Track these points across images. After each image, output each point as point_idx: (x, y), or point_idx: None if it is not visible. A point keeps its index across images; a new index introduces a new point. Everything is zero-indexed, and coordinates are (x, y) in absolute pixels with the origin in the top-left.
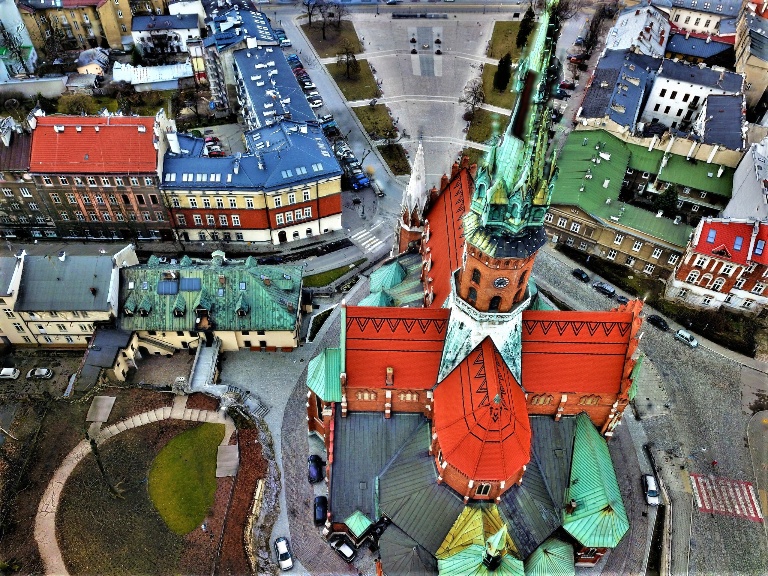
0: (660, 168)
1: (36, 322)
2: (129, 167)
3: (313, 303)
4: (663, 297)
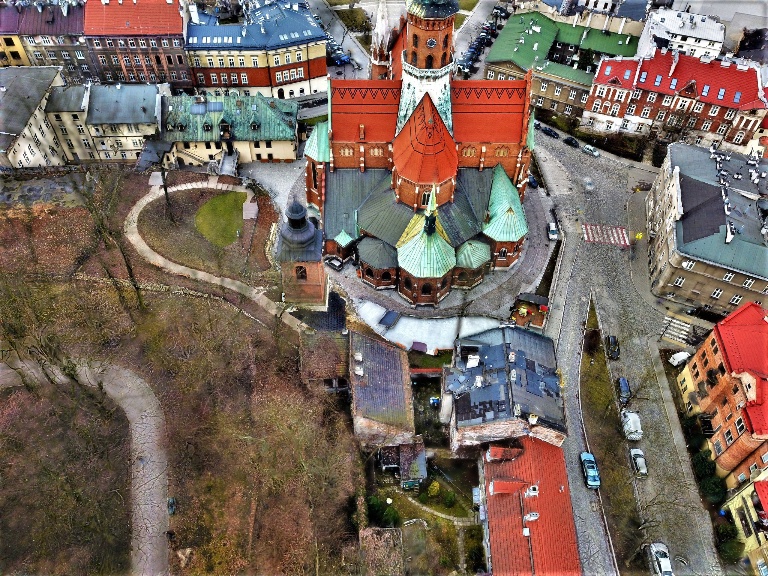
0: (581, 39)
1: (100, 138)
2: (161, 30)
3: (307, 135)
4: (577, 128)
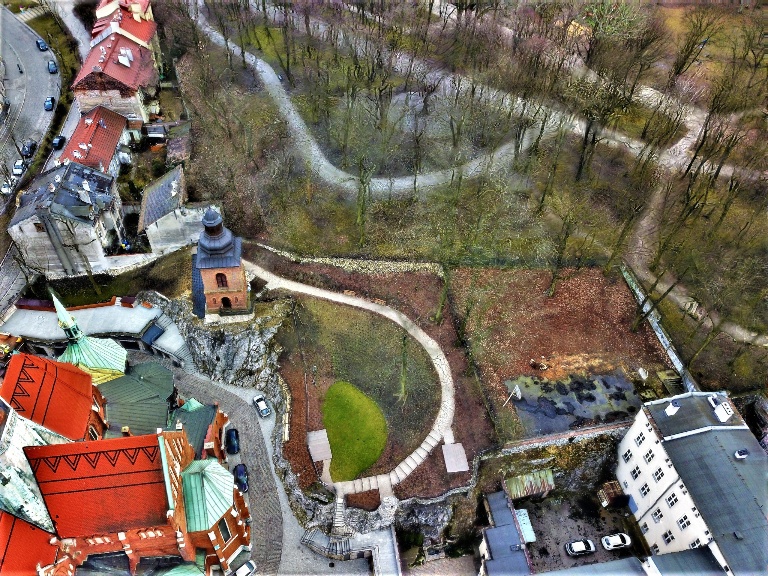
0: None
1: None
2: None
3: None
4: None
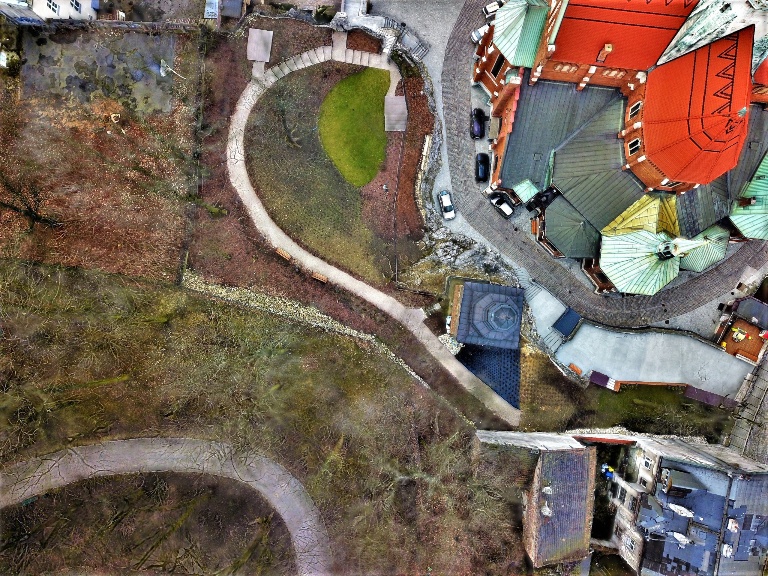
0: None
1: None
2: None
3: None
4: None
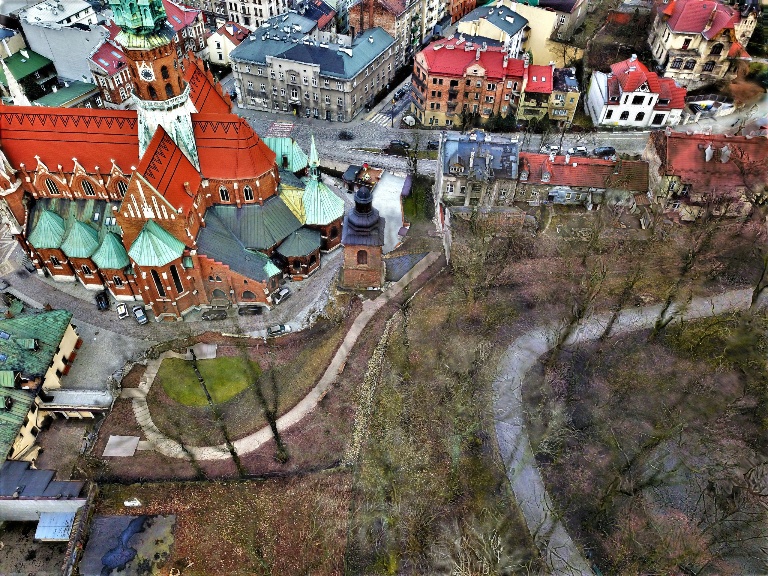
0: None
1: None
2: None
3: None
4: None
